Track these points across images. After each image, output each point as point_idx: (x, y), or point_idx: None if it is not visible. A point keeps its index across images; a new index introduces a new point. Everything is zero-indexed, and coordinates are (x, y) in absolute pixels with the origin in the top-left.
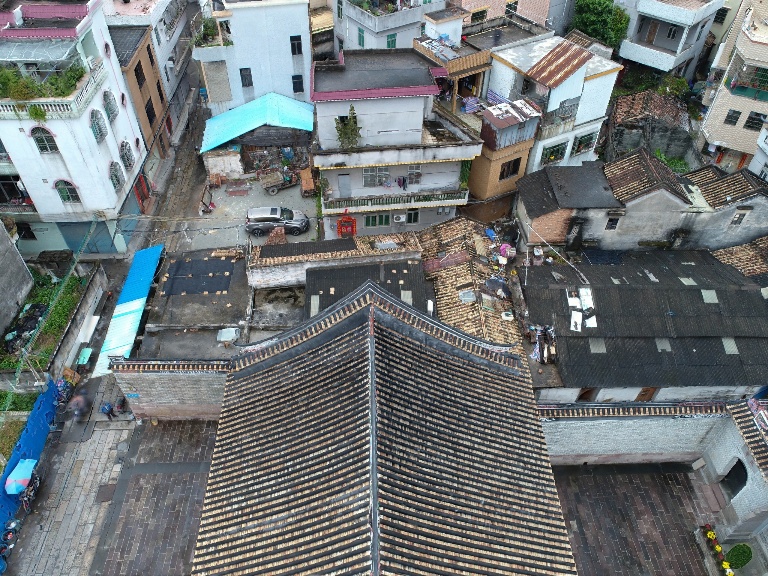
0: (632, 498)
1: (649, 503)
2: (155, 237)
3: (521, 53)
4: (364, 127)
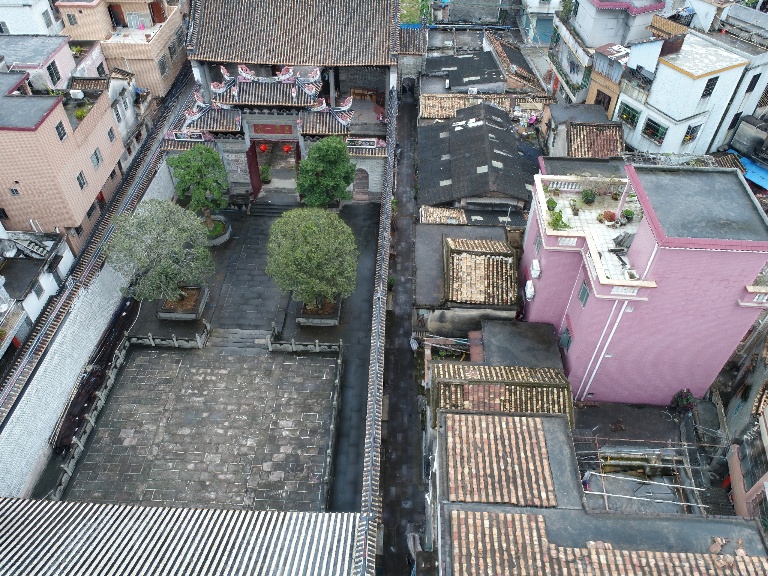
0: (366, 174)
1: (362, 178)
2: (521, 28)
3: (695, 42)
4: (578, 14)
